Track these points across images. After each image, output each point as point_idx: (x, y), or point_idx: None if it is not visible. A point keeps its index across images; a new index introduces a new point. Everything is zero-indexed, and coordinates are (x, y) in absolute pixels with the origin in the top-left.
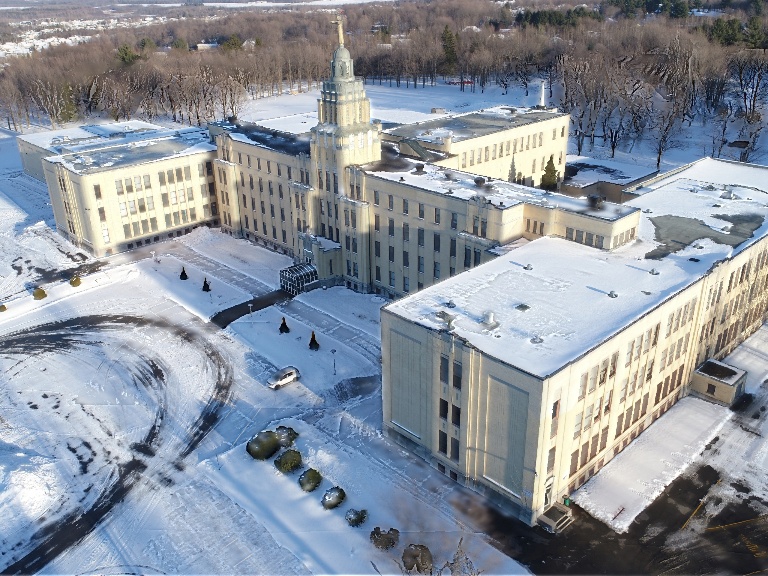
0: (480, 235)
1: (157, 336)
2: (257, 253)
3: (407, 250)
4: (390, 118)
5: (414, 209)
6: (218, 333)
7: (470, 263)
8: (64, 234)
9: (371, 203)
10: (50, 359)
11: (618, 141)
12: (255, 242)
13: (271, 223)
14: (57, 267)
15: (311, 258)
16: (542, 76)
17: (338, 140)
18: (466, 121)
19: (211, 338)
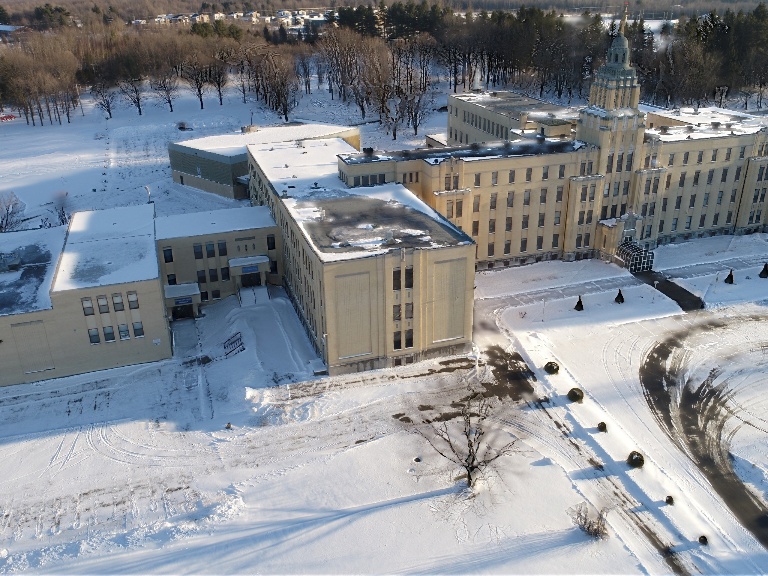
0: (763, 155)
1: (710, 339)
2: (528, 271)
3: (695, 193)
4: (241, 144)
5: (709, 156)
6: (713, 311)
7: (763, 177)
8: (360, 366)
9: (665, 166)
10: (747, 402)
11: (422, 120)
12: (490, 269)
13: (521, 236)
14: (477, 383)
15: (633, 235)
16: (155, 91)
17: (642, 119)
18: (507, 106)
19: (724, 315)
